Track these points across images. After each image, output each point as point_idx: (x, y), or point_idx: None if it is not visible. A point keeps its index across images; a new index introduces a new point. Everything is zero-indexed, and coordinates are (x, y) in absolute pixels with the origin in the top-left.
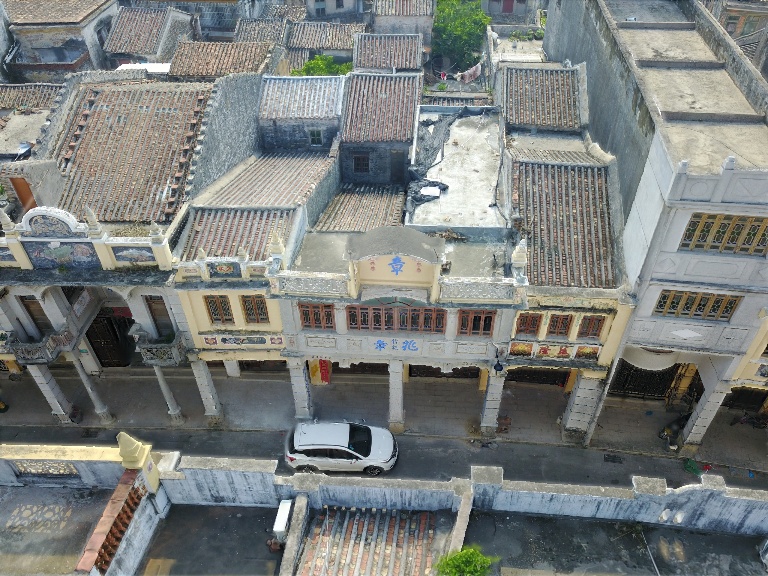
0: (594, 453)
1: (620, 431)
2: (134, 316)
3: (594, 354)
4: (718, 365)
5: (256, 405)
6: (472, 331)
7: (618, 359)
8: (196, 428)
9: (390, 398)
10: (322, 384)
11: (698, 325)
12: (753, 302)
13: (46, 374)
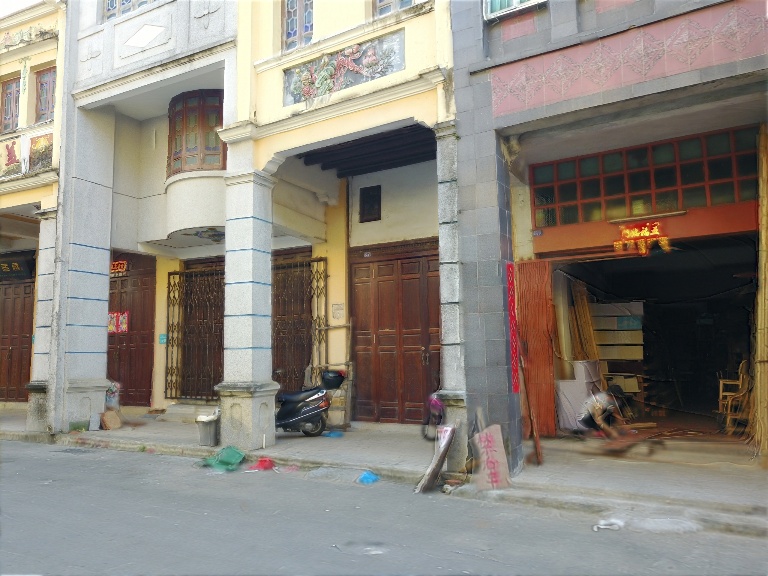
0: None
1: (157, 432)
2: None
3: None
4: None
5: None
6: None
7: (64, 133)
8: None
9: None
10: None
11: (155, 9)
12: None
13: None
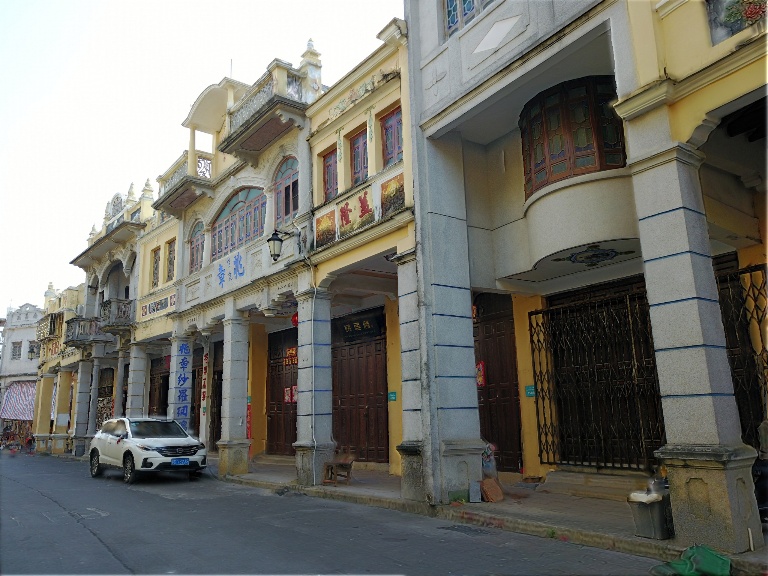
0: None
1: (554, 509)
2: None
3: (403, 193)
4: None
5: None
6: (285, 218)
7: (416, 167)
8: None
9: (223, 386)
10: None
11: (505, 1)
12: None
13: (85, 384)
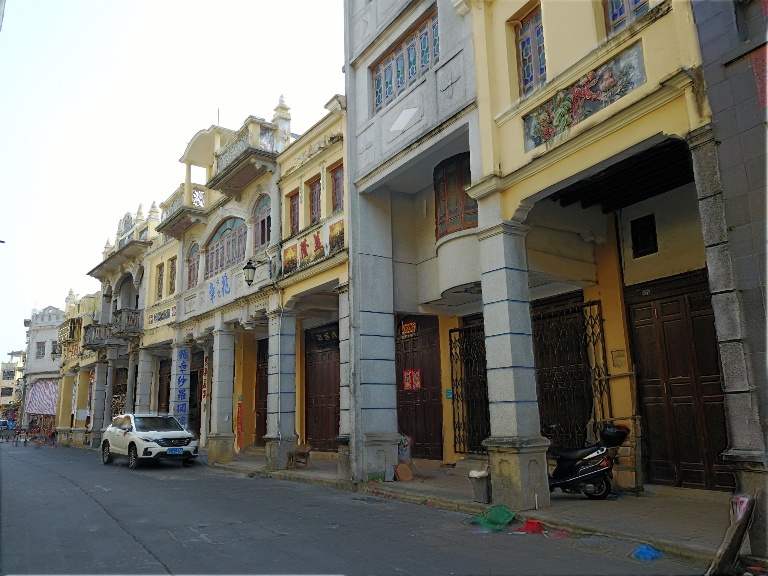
0: None
1: (442, 486)
2: (138, 308)
3: None
4: None
5: None
6: (261, 246)
7: (350, 217)
8: None
9: None
10: (237, 452)
11: (409, 93)
12: None
13: (101, 383)
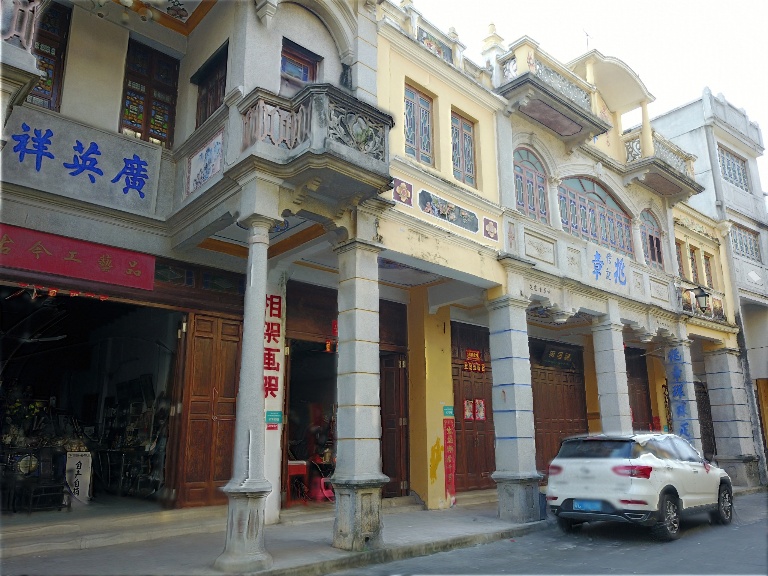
0: None
1: None
2: (246, 83)
3: (721, 312)
4: (767, 338)
5: (389, 530)
6: (651, 261)
7: (740, 309)
8: (320, 564)
9: (618, 401)
10: (446, 506)
11: (755, 265)
12: (765, 240)
13: None
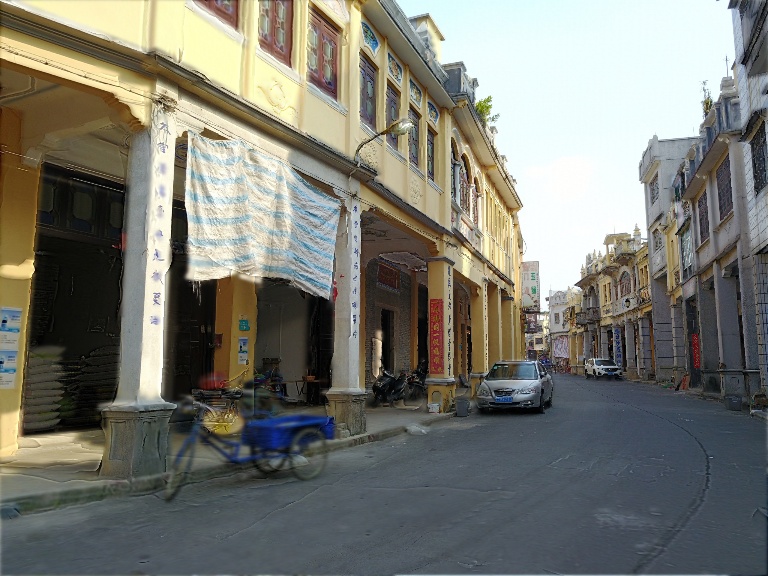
0: (655, 385)
1: None
2: None
3: None
4: None
5: None
6: None
7: (651, 289)
8: None
9: None
10: None
11: None
12: None
13: (587, 342)
